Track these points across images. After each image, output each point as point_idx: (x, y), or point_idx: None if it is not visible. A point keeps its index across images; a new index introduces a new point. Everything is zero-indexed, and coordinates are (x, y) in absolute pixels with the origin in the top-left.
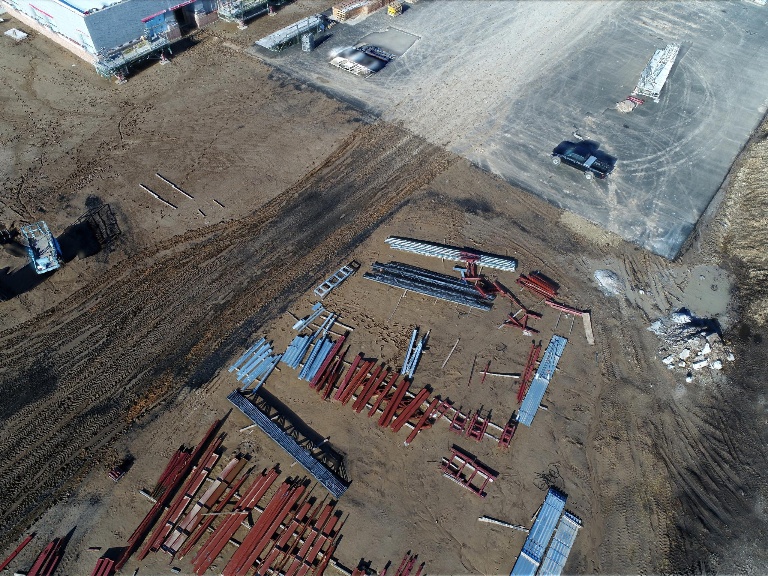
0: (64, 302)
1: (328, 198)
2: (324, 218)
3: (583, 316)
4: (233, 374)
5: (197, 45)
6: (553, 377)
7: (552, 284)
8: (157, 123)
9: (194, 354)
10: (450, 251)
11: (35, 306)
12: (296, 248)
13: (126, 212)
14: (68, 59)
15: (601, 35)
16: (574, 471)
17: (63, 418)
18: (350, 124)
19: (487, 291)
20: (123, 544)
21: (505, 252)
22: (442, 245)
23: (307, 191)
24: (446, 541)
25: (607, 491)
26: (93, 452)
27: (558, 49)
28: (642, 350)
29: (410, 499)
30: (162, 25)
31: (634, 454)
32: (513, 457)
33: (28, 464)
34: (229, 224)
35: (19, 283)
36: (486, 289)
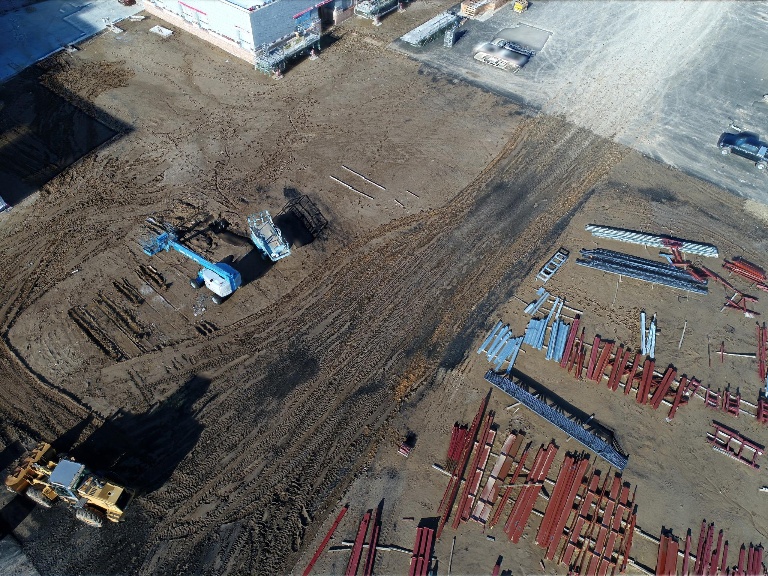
0: (297, 288)
1: (516, 188)
2: (519, 207)
3: None
4: (482, 355)
5: (339, 41)
6: None
7: None
8: (326, 117)
9: (438, 337)
10: (652, 238)
11: (271, 292)
12: (502, 236)
13: (326, 202)
14: (220, 55)
15: (726, 30)
16: None
17: (336, 398)
18: (513, 117)
19: (698, 276)
20: (433, 515)
21: (702, 239)
22: (640, 232)
23: (493, 182)
24: (735, 510)
25: None
26: (376, 429)
27: (689, 44)
28: None
29: (689, 471)
30: (308, 22)
31: None
32: None
33: (318, 441)
34: (429, 213)
35: (248, 271)
36: (697, 274)
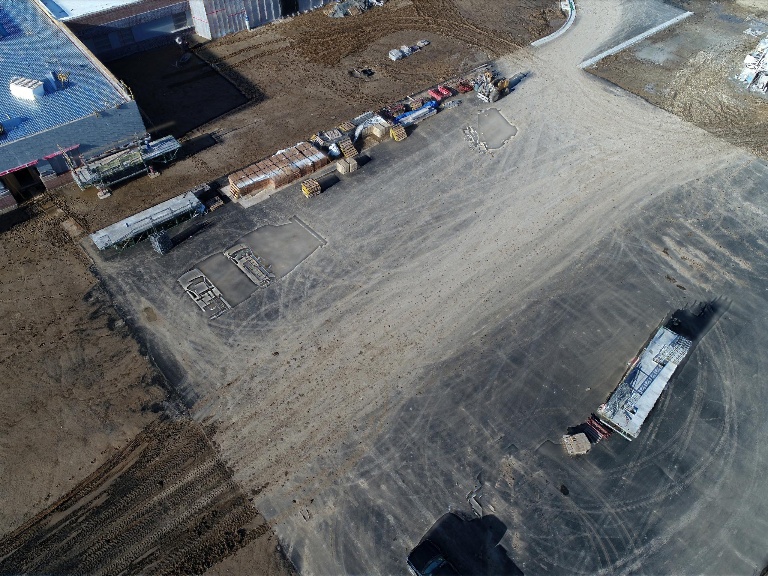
0: None
1: None
2: None
3: None
4: None
5: (29, 221)
6: None
7: None
8: None
9: None
10: None
11: None
12: None
13: None
14: None
15: (590, 270)
16: None
17: None
18: (143, 415)
19: None
20: None
21: None
22: None
23: (2, 566)
24: None
25: None
26: None
27: (515, 292)
28: None
29: None
30: None
31: None
32: None
33: None
34: None
35: None
36: None
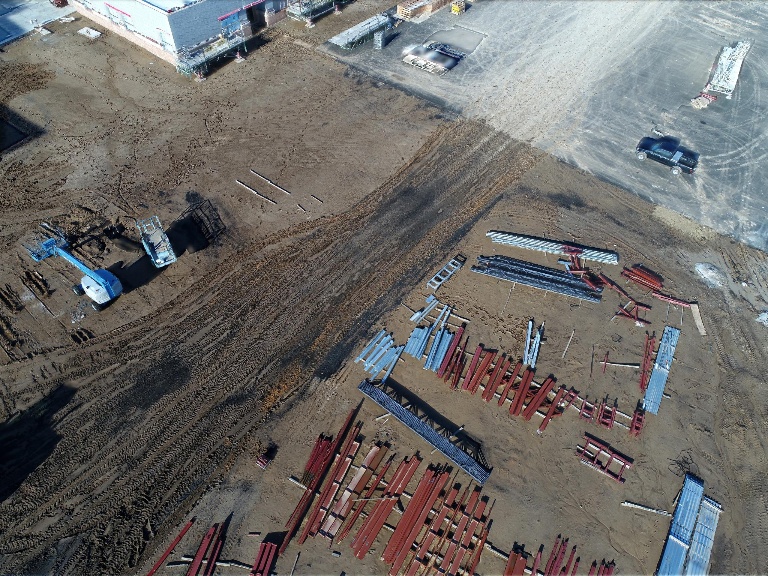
0: (182, 295)
1: (423, 193)
2: (422, 213)
3: (692, 308)
4: (359, 365)
5: (269, 43)
6: (671, 367)
7: (656, 277)
8: (242, 120)
9: (318, 345)
10: (552, 245)
11: (154, 299)
12: (400, 242)
13: (227, 207)
14: (145, 57)
15: (664, 33)
16: (706, 458)
17: (202, 408)
18: (432, 121)
19: (594, 284)
20: (281, 529)
21: (605, 246)
22: (542, 239)
23: (401, 186)
24: (593, 525)
25: (741, 477)
26: (237, 440)
27: (624, 47)
28: (754, 340)
29: (552, 485)
30: (235, 23)
31: (762, 441)
32: (645, 444)
33: (176, 452)
34: (330, 219)
35: (135, 277)
36: (593, 282)
